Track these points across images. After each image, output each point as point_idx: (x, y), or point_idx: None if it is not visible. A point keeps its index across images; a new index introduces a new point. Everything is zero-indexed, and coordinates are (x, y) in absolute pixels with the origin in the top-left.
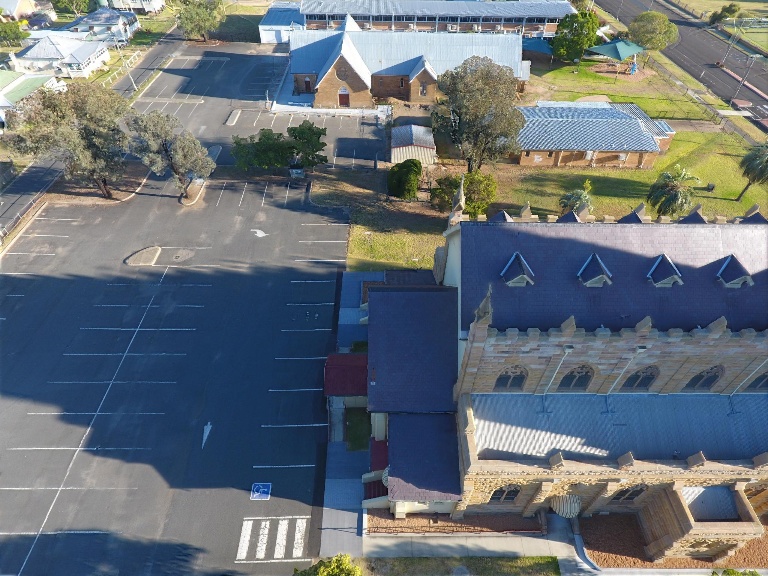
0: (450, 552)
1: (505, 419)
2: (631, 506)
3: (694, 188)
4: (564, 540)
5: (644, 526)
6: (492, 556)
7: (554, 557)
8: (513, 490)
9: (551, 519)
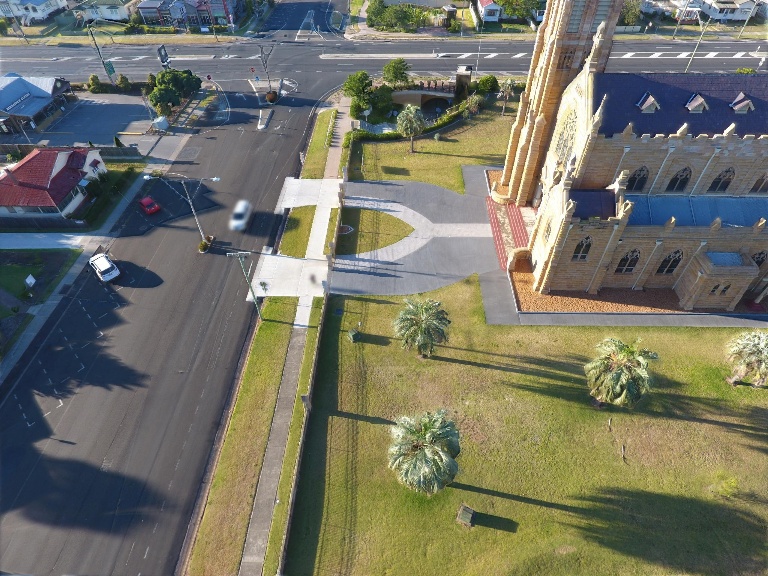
0: None
1: None
2: None
3: (494, 521)
4: None
5: None
6: None
7: None
8: None
9: None
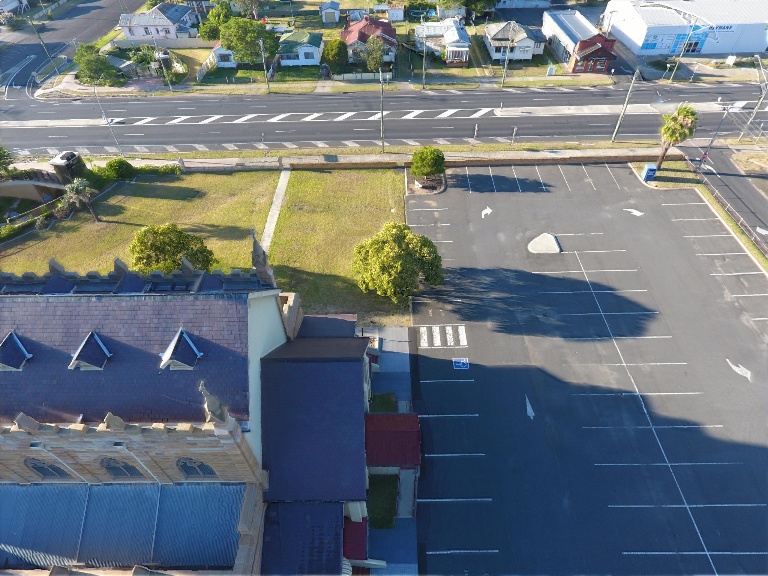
0: None
1: None
2: None
3: None
4: None
5: None
6: None
7: None
8: None
9: None
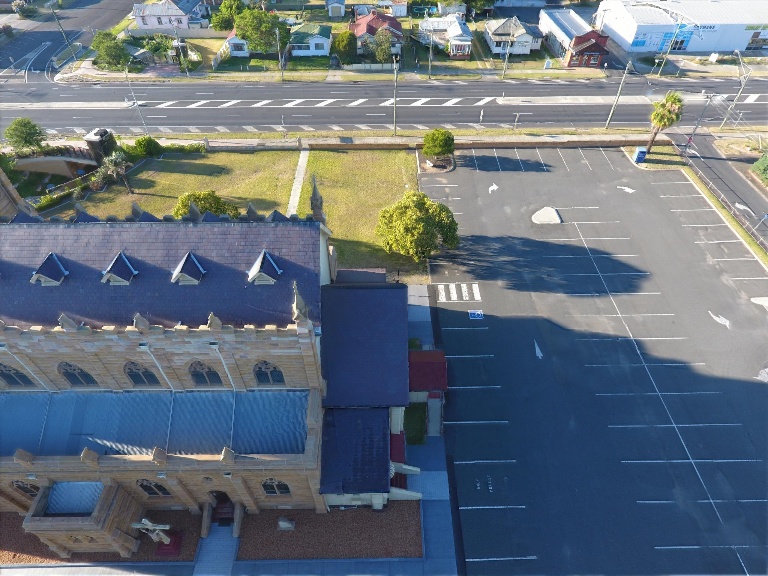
0: None
1: None
2: None
3: None
4: None
5: None
6: None
7: None
8: None
9: None
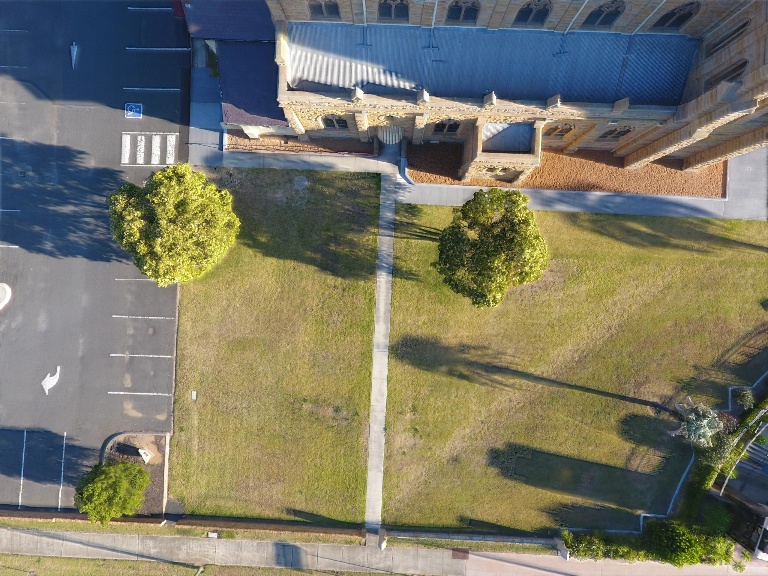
0: (294, 166)
1: (324, 51)
2: (455, 137)
3: None
4: (391, 161)
5: (464, 154)
6: (328, 170)
7: (379, 173)
8: (340, 119)
9: (385, 145)
